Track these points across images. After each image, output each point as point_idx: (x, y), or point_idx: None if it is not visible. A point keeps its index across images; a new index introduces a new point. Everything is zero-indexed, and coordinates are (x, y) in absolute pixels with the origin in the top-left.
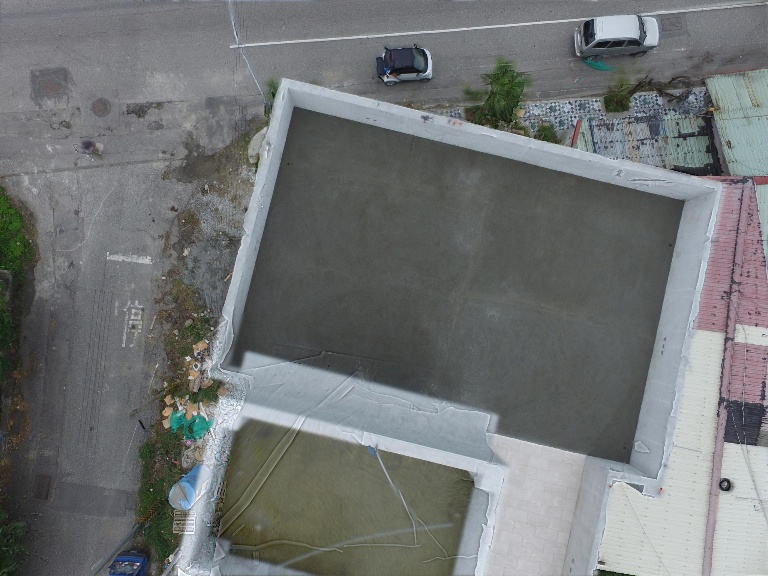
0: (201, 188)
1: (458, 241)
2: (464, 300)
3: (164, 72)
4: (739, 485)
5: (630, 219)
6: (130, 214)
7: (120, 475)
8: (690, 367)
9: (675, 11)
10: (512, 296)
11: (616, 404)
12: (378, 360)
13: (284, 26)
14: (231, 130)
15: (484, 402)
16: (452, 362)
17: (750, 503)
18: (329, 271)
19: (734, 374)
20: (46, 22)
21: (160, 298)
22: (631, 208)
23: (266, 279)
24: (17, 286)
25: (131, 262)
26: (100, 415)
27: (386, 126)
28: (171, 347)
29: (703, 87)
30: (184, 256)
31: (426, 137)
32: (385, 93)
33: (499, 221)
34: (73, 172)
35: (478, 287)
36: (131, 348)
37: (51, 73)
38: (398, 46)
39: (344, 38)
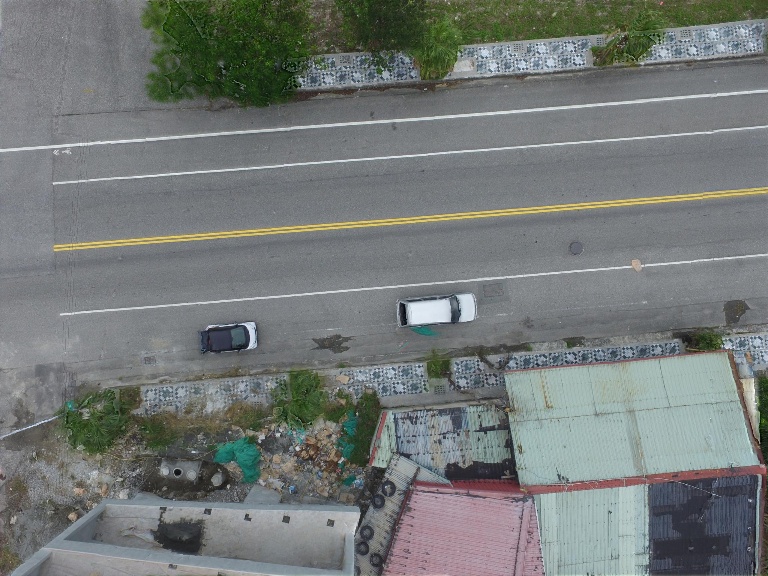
0: (29, 455)
1: None
2: None
3: None
4: None
5: None
6: None
7: None
8: None
9: (497, 277)
10: None
11: None
12: None
13: (114, 293)
14: (60, 396)
15: None
16: None
17: None
18: None
19: None
20: None
21: None
22: None
23: None
24: None
25: None
26: None
27: None
28: None
29: (523, 352)
30: (11, 524)
31: None
32: (213, 359)
33: None
34: None
35: None
36: None
37: None
38: (226, 313)
39: (173, 305)
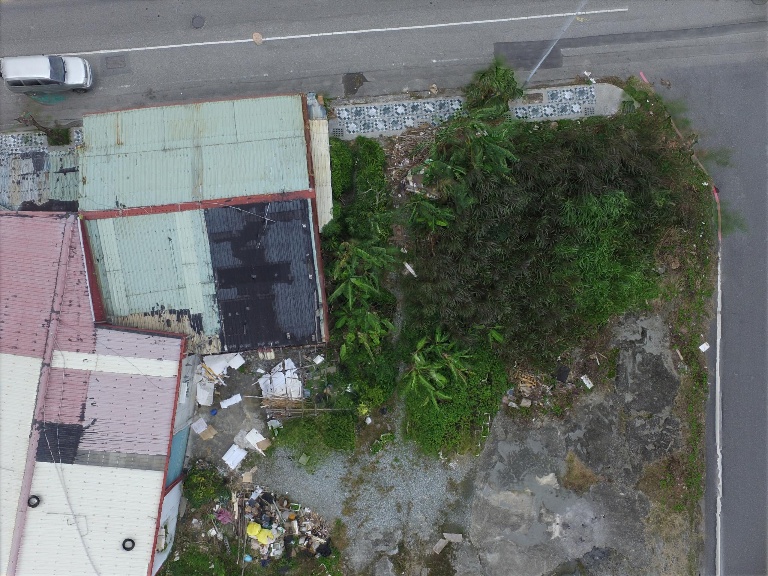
0: None
1: None
2: None
3: None
4: (51, 501)
5: None
6: None
7: None
8: (9, 391)
9: (119, 50)
10: None
11: None
12: None
13: None
14: None
15: None
16: None
17: (63, 518)
18: None
19: (50, 397)
20: None
21: None
22: None
23: None
24: None
25: None
26: None
27: None
28: None
29: None
30: None
31: None
32: None
33: None
34: None
35: None
36: None
37: None
38: None
39: None
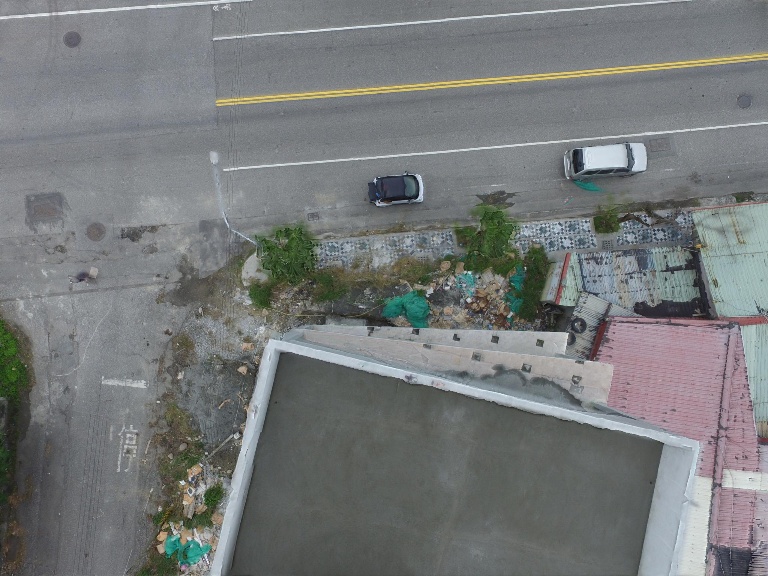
0: (195, 311)
1: (443, 481)
2: (449, 540)
3: (158, 196)
4: None
5: (611, 457)
6: (125, 338)
7: None
8: None
9: (663, 132)
10: (496, 535)
11: None
12: None
13: (277, 149)
14: (225, 252)
15: None
16: None
17: None
18: (316, 511)
19: (722, 519)
20: (41, 148)
21: (154, 422)
22: (612, 446)
23: (254, 526)
24: (12, 411)
25: (126, 386)
26: (95, 541)
27: None
28: (165, 472)
29: (691, 207)
30: (178, 379)
31: None
32: (377, 215)
33: (483, 460)
34: (68, 297)
35: (462, 527)
36: (126, 473)
37: (46, 198)
38: (390, 168)
39: (336, 160)
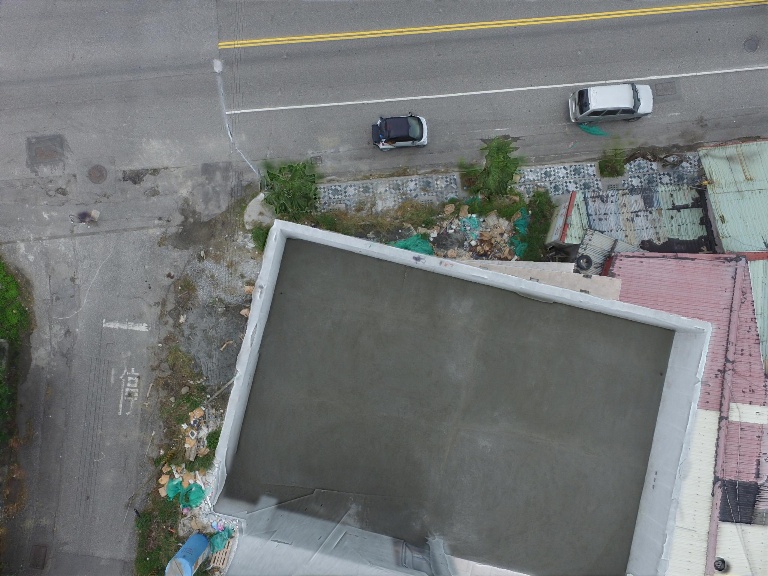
0: (197, 254)
1: (450, 371)
2: (456, 431)
3: (160, 138)
4: (734, 564)
5: (621, 348)
6: (126, 281)
7: (116, 544)
8: None
9: (669, 76)
10: (504, 426)
11: (608, 535)
12: (371, 495)
13: (280, 92)
14: (227, 196)
15: (477, 534)
16: (445, 493)
17: None
18: (322, 402)
19: (728, 453)
20: (42, 89)
21: (156, 365)
22: (622, 337)
23: (259, 414)
24: (13, 354)
25: (127, 329)
26: (96, 484)
27: (378, 257)
28: (167, 415)
29: None
30: (180, 323)
31: (418, 267)
32: (381, 158)
33: (491, 351)
34: (69, 239)
35: (470, 418)
36: (127, 416)
37: (47, 140)
38: (393, 111)
39: (340, 104)
